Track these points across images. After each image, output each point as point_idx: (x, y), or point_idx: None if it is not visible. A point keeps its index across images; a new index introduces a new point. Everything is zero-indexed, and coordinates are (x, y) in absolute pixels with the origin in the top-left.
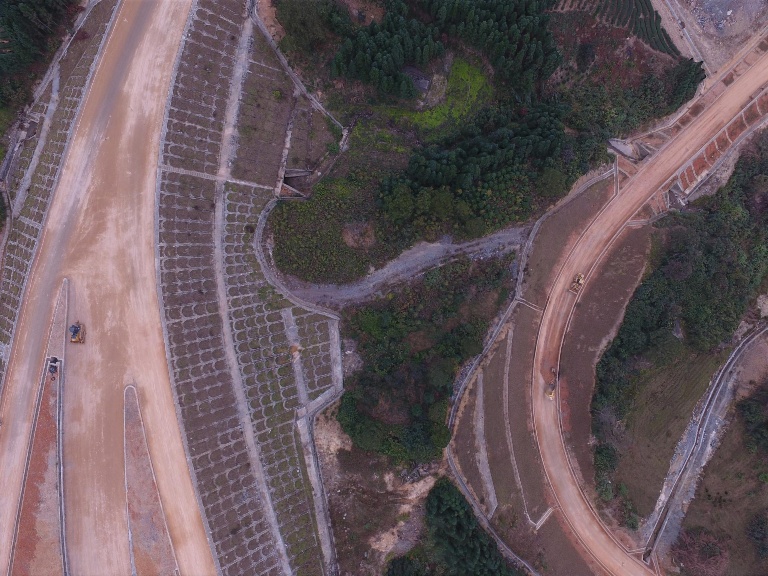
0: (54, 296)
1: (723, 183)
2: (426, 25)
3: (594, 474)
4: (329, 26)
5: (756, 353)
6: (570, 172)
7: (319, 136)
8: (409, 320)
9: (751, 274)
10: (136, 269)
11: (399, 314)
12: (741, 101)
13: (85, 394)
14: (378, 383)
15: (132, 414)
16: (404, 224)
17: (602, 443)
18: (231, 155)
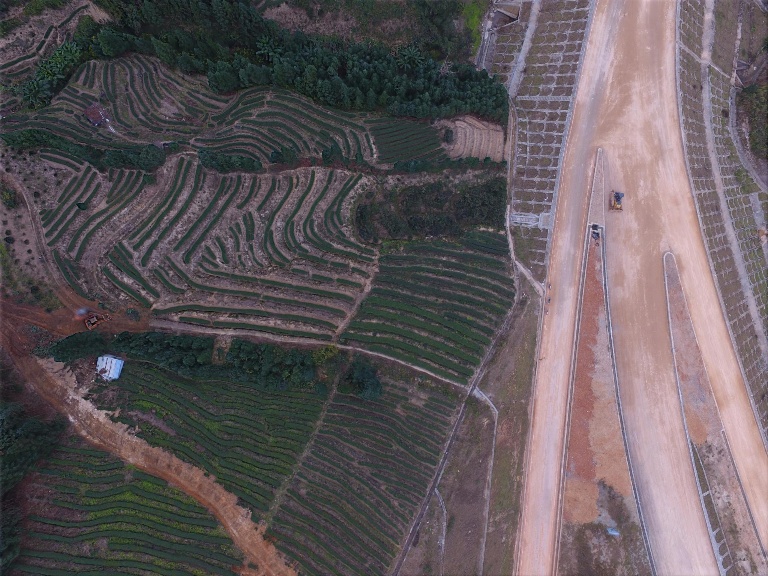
0: (589, 166)
1: None
2: None
3: None
4: None
5: None
6: None
7: (759, 30)
8: None
9: None
10: (663, 141)
11: None
12: None
13: (625, 260)
14: None
15: (674, 279)
16: None
17: None
18: (711, 39)
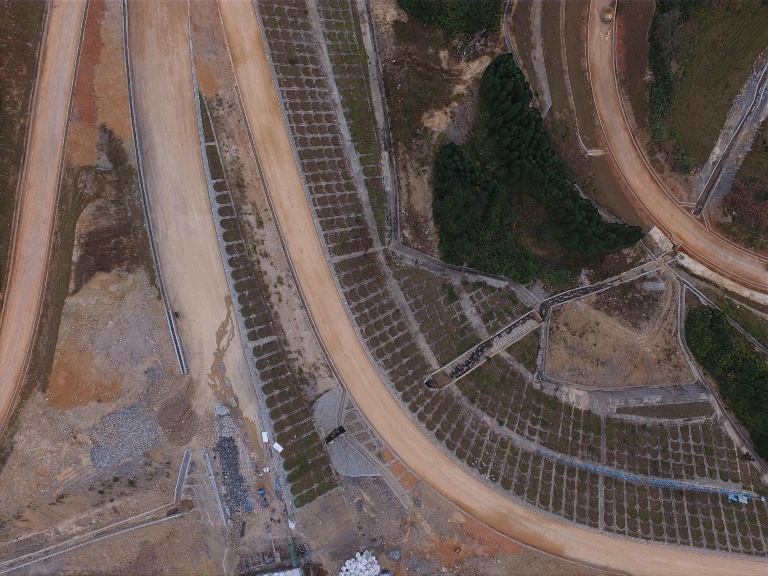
0: None
1: None
2: None
3: (648, 113)
4: None
5: None
6: None
7: None
8: None
9: None
10: None
11: None
12: None
13: None
14: None
15: None
16: None
17: (659, 77)
18: None
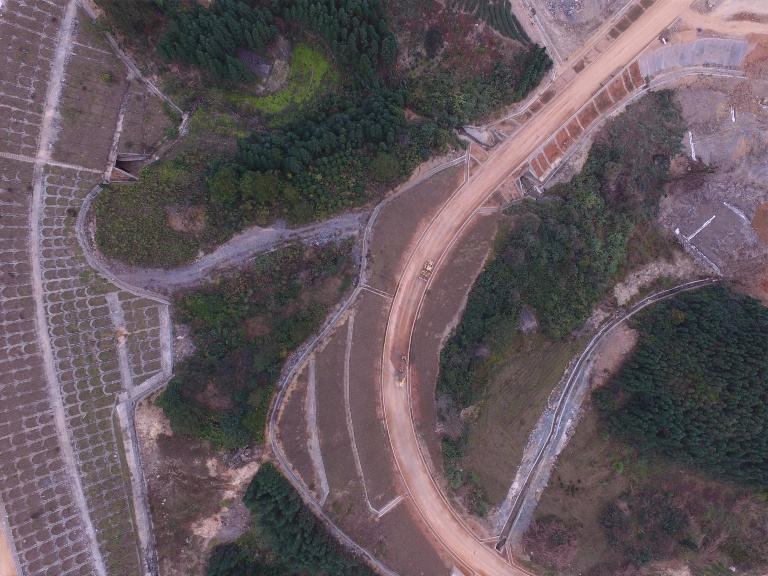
0: None
1: (577, 171)
2: (260, 9)
3: (442, 462)
4: (156, 8)
5: (612, 341)
6: (407, 157)
7: (155, 120)
8: (240, 305)
9: (605, 262)
10: None
11: (230, 299)
12: (592, 88)
13: None
14: (205, 368)
15: None
16: (233, 208)
17: None
18: (52, 137)
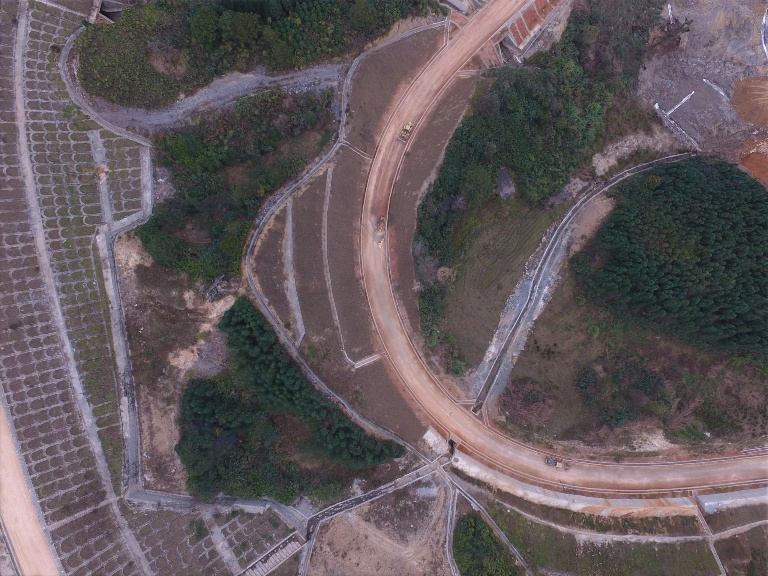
0: None
1: (556, 38)
2: None
3: (419, 320)
4: None
5: (590, 210)
6: (386, 9)
7: None
8: (219, 148)
9: (583, 129)
10: None
11: (210, 142)
12: None
13: None
14: (184, 207)
15: None
16: None
17: (426, 288)
18: None
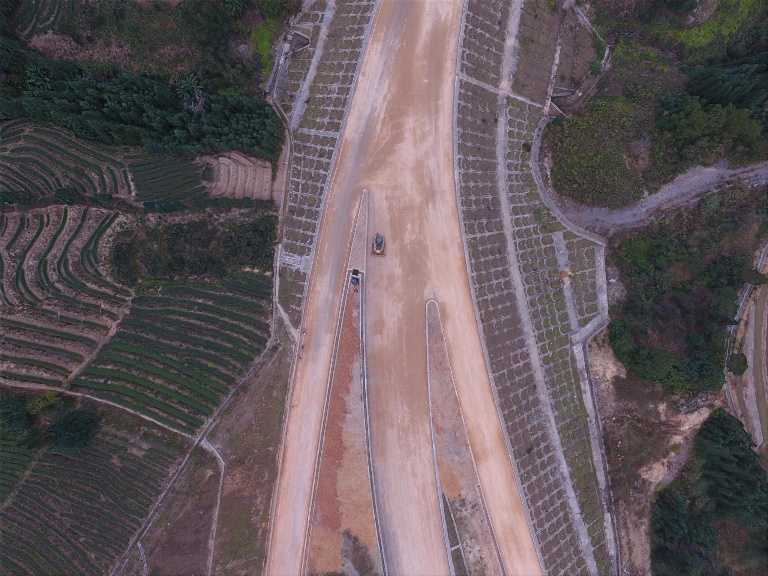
0: (353, 207)
1: None
2: None
3: None
4: None
5: None
6: None
7: (584, 53)
8: (681, 248)
9: None
10: (435, 181)
11: None
12: None
13: (386, 307)
14: (649, 312)
15: (435, 329)
16: (684, 145)
17: None
18: (512, 67)
